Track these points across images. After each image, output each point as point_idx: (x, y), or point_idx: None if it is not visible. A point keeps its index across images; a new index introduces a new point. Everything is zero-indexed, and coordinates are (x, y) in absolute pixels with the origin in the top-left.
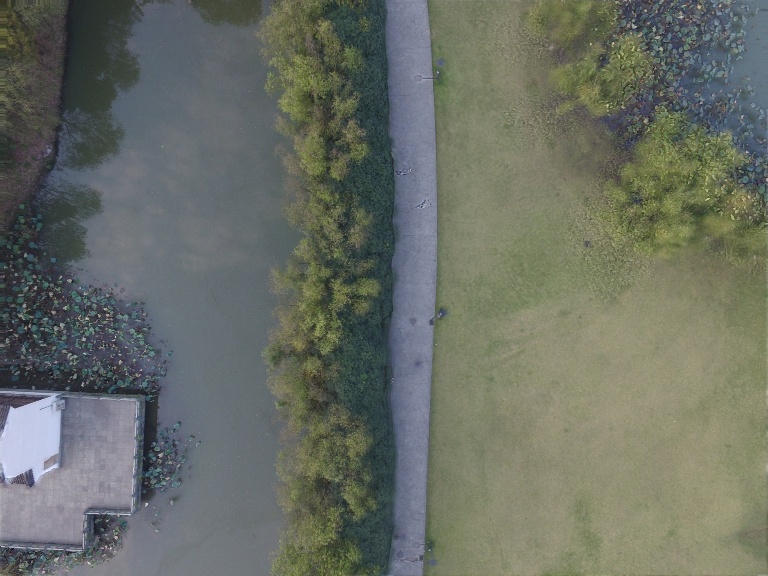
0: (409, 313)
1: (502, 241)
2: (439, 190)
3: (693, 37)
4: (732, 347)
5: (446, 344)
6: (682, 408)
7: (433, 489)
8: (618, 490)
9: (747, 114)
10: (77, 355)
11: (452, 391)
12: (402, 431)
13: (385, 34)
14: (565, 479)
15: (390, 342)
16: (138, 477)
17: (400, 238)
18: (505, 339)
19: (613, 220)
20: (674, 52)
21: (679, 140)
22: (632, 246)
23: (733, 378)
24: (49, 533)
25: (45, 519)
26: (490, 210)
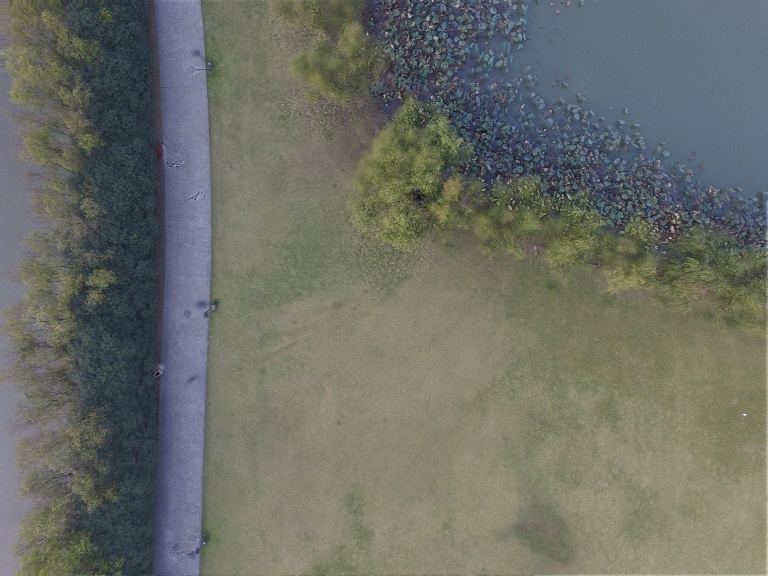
0: (183, 305)
1: (275, 233)
2: (213, 182)
3: (468, 26)
4: (511, 339)
5: (220, 336)
6: (459, 400)
7: (208, 482)
8: (391, 483)
9: (528, 103)
10: None
11: (225, 383)
12: (177, 424)
13: (154, 25)
14: (337, 472)
15: (163, 334)
16: None
17: (174, 230)
18: (277, 331)
19: (390, 211)
20: (449, 41)
21: (455, 130)
22: (411, 237)
23: (511, 370)
24: None
25: None
26: (263, 202)
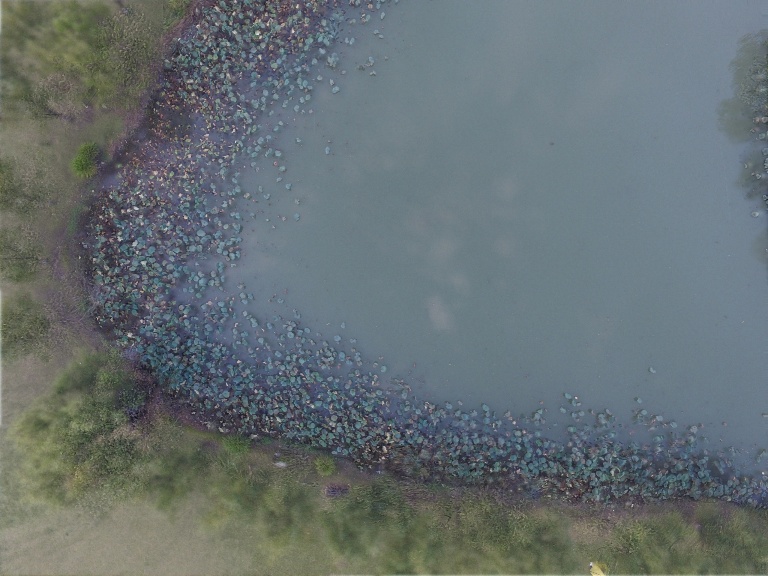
0: None
1: None
2: None
3: (176, 250)
4: (226, 561)
5: None
6: None
7: None
8: None
9: (240, 322)
10: None
11: None
12: None
13: None
14: None
15: None
16: None
17: None
18: None
19: (104, 433)
20: (156, 266)
21: (165, 353)
22: (126, 459)
23: None
24: None
25: None
26: None
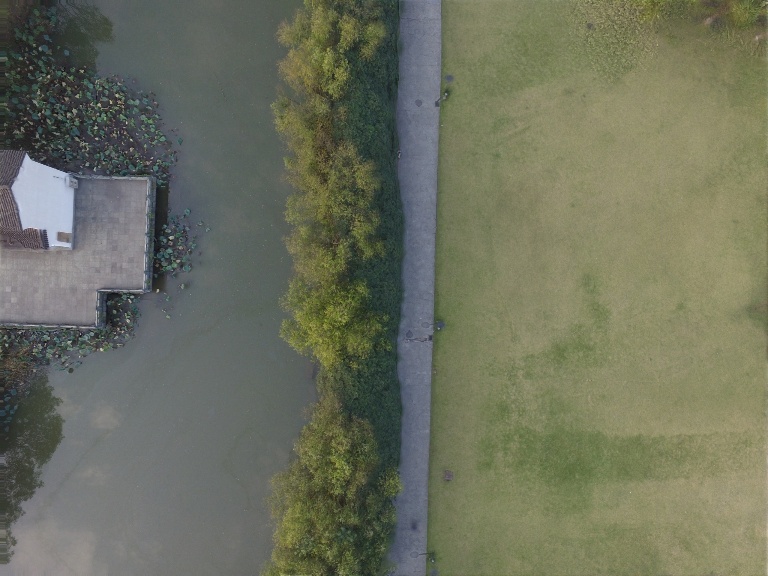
0: (415, 95)
1: (505, 21)
2: None
3: None
4: (737, 126)
5: (452, 124)
6: (688, 185)
7: (441, 268)
8: (626, 264)
9: None
10: (89, 143)
11: (458, 169)
12: (410, 212)
13: None
14: (573, 253)
15: (396, 122)
16: (150, 255)
17: (405, 21)
18: (510, 117)
19: (615, 3)
20: None
21: None
22: (634, 29)
23: (738, 155)
24: (62, 314)
25: (58, 301)
26: None
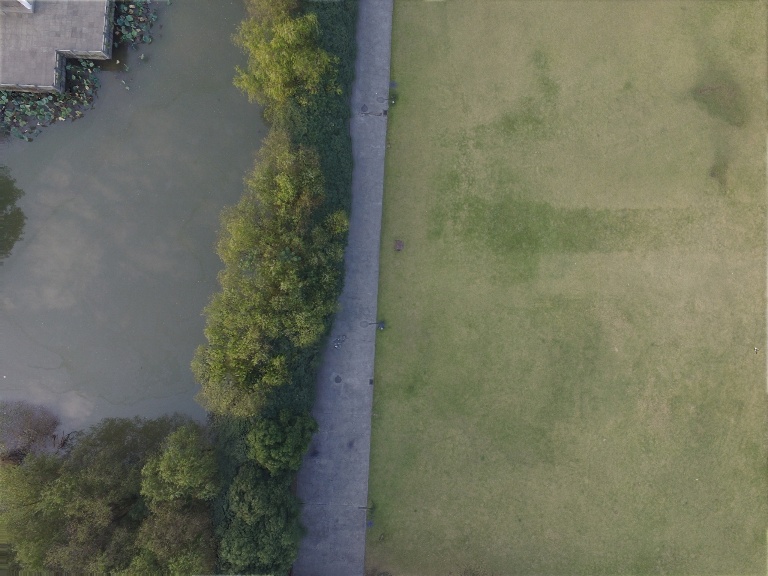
0: None
1: None
2: None
3: None
4: None
5: None
6: None
7: (397, 45)
8: (576, 43)
9: None
10: None
11: None
12: None
13: None
14: (525, 30)
15: None
16: (110, 19)
17: None
18: None
19: None
20: None
21: None
22: None
23: None
24: (21, 77)
25: (18, 63)
26: None
